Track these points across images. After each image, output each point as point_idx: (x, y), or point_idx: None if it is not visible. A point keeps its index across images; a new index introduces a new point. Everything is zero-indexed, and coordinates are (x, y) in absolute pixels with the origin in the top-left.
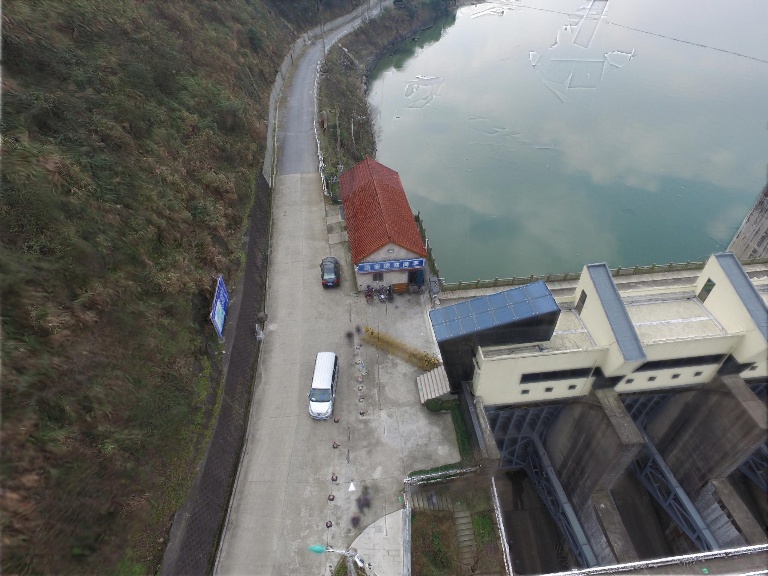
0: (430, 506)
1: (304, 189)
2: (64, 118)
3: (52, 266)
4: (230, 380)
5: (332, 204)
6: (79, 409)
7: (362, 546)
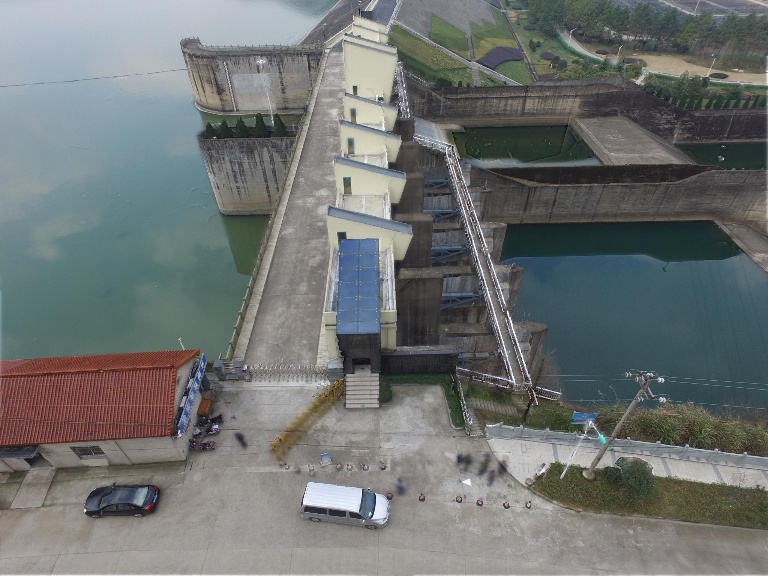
0: (475, 420)
1: None
2: None
3: None
4: None
5: None
6: None
7: (522, 474)
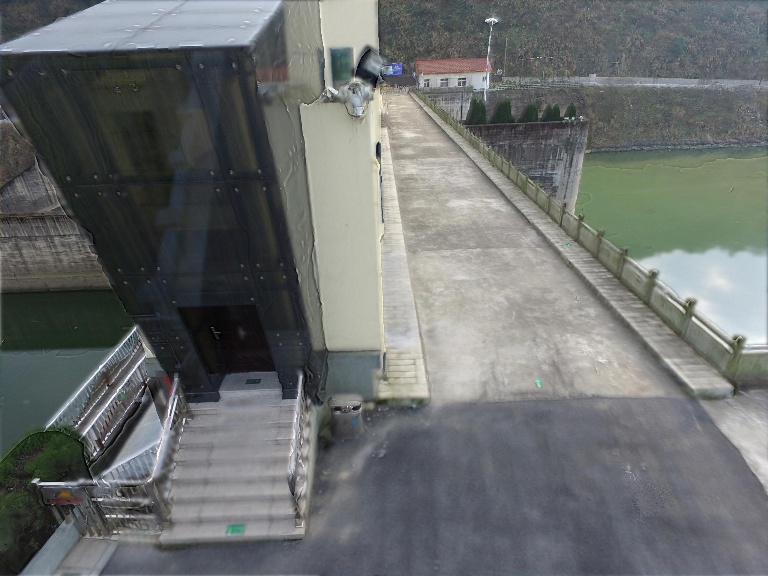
0: None
1: None
2: (428, 15)
3: None
4: None
5: None
6: None
7: None
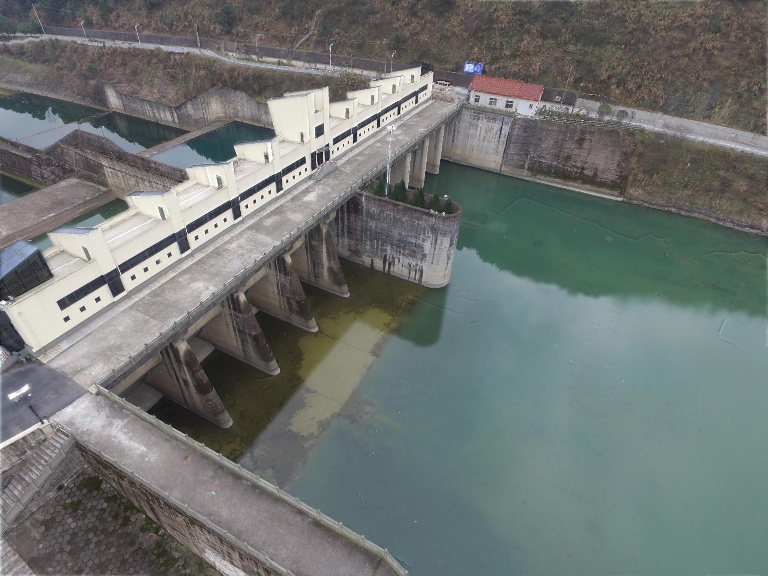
0: None
1: None
2: (531, 16)
3: (470, 25)
4: (451, 74)
5: None
6: (441, 42)
7: None
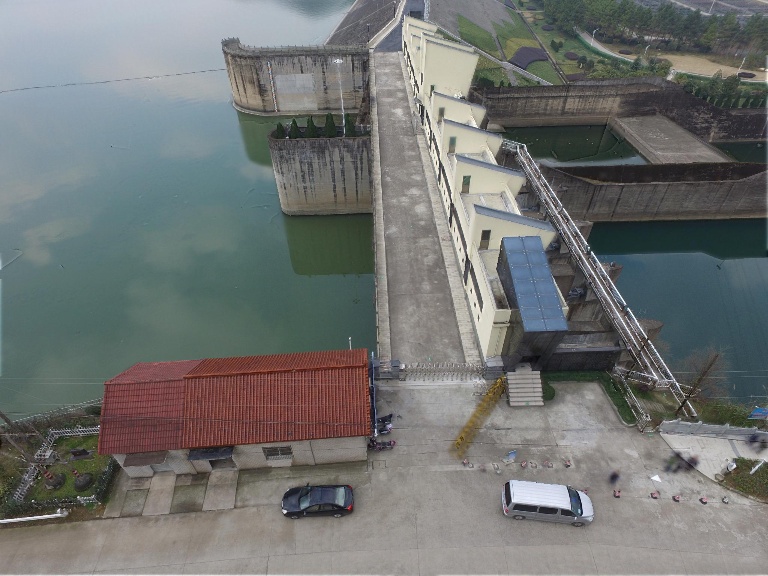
0: None
1: (0, 571)
2: None
3: None
4: None
5: (106, 503)
6: None
7: (709, 470)
